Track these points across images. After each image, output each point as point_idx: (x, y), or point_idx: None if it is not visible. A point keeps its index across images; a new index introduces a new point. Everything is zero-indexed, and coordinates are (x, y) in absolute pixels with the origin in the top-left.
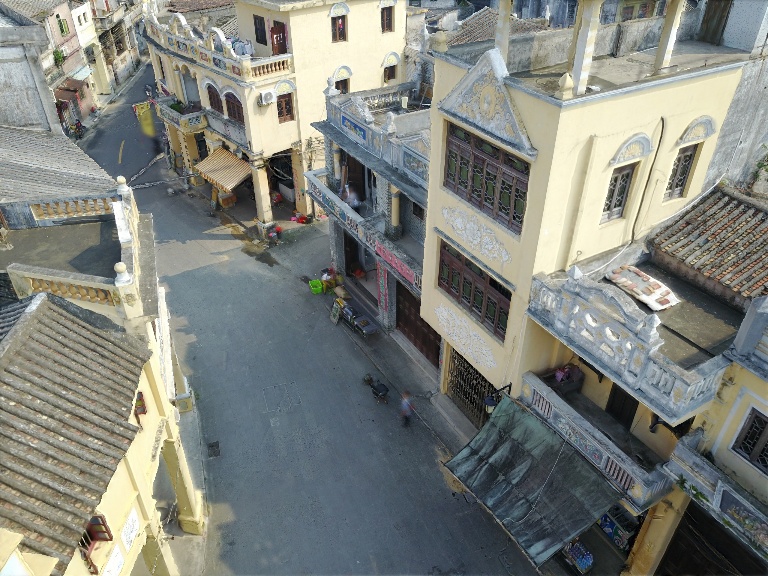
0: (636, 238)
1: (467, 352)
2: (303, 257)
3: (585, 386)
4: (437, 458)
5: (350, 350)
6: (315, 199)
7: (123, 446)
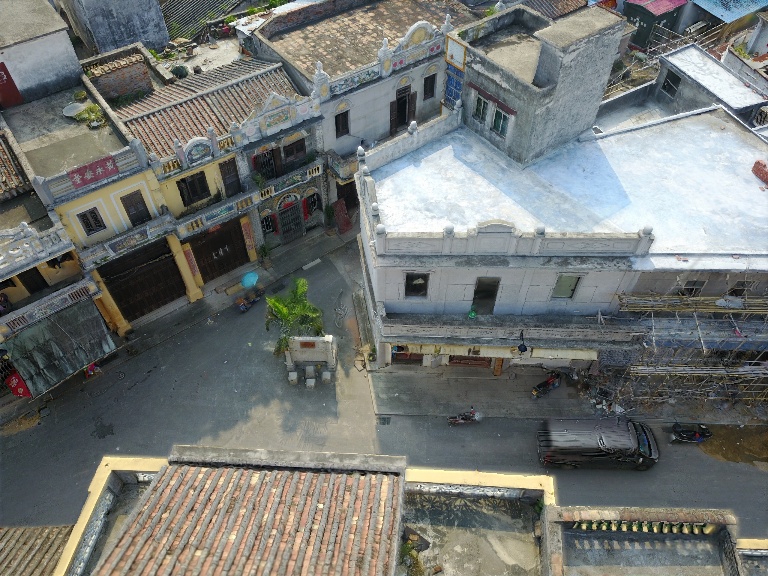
0: None
1: None
2: None
3: (10, 299)
4: (4, 436)
5: None
6: None
7: (6, 530)
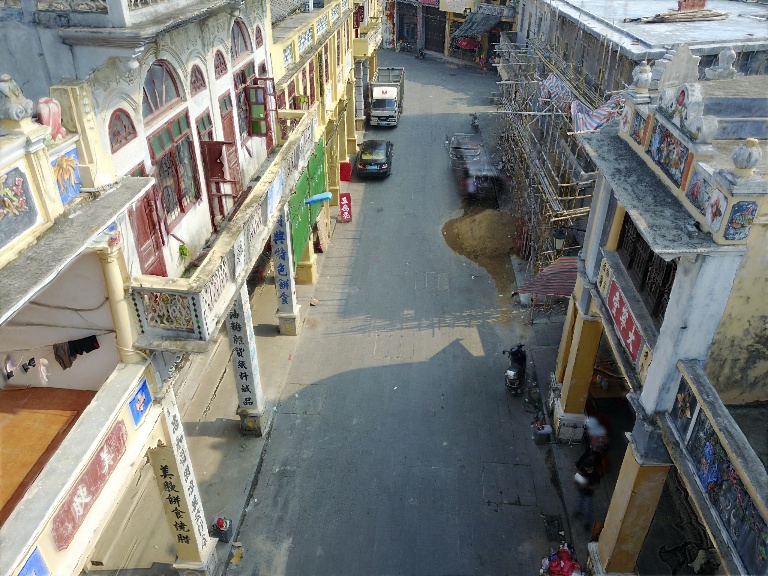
0: None
1: (457, 9)
2: None
3: None
4: None
5: (407, 55)
6: None
7: None
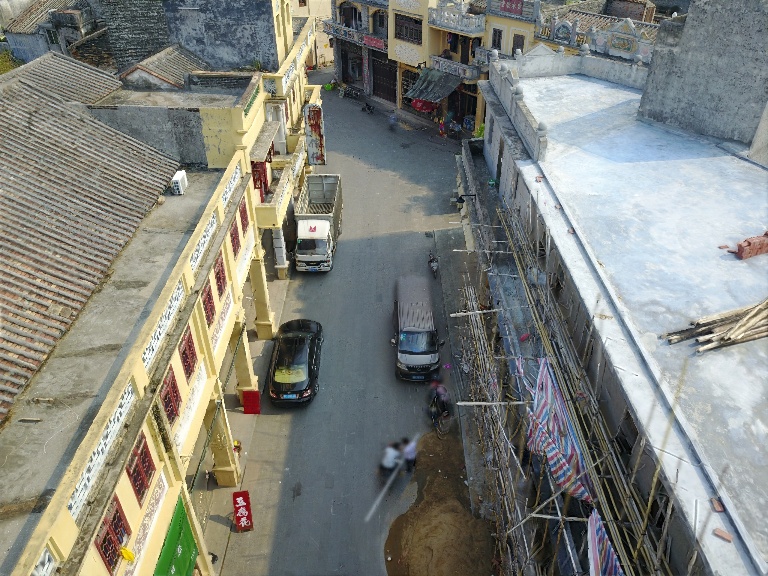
0: (465, 2)
1: (408, 60)
2: (317, 81)
3: None
4: None
5: (352, 104)
6: (329, 33)
7: None
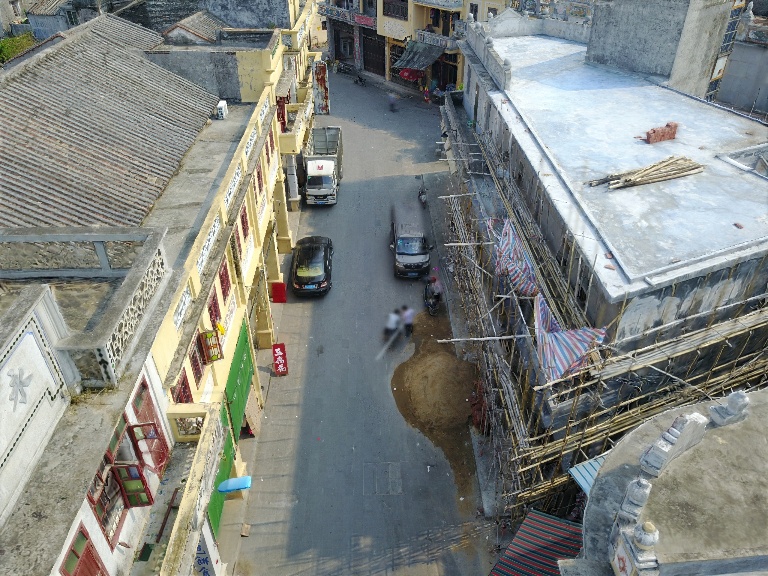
0: None
1: (396, 35)
2: None
3: None
4: None
5: (345, 78)
6: (322, 14)
7: None
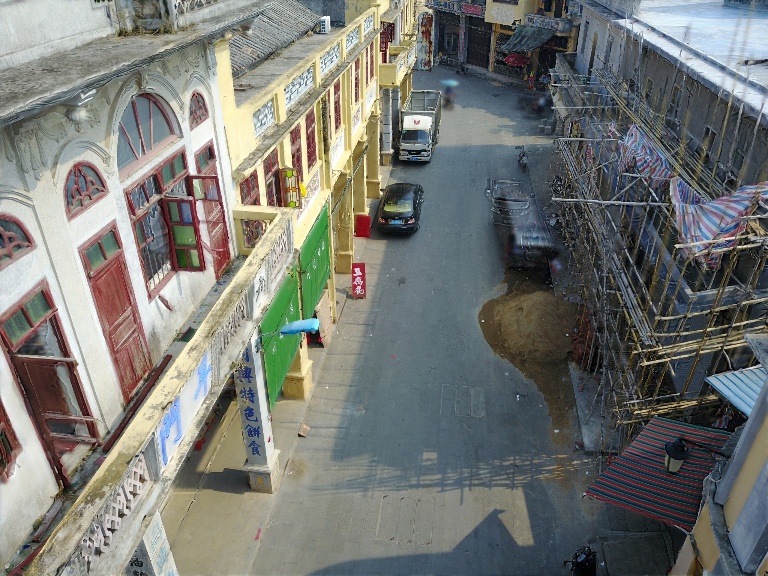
0: None
1: (504, 21)
2: None
3: None
4: None
5: None
6: (430, 6)
7: None
